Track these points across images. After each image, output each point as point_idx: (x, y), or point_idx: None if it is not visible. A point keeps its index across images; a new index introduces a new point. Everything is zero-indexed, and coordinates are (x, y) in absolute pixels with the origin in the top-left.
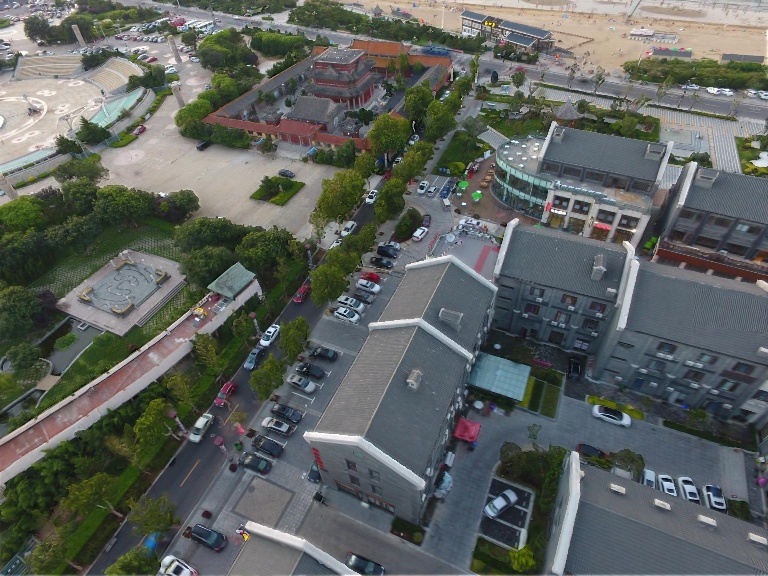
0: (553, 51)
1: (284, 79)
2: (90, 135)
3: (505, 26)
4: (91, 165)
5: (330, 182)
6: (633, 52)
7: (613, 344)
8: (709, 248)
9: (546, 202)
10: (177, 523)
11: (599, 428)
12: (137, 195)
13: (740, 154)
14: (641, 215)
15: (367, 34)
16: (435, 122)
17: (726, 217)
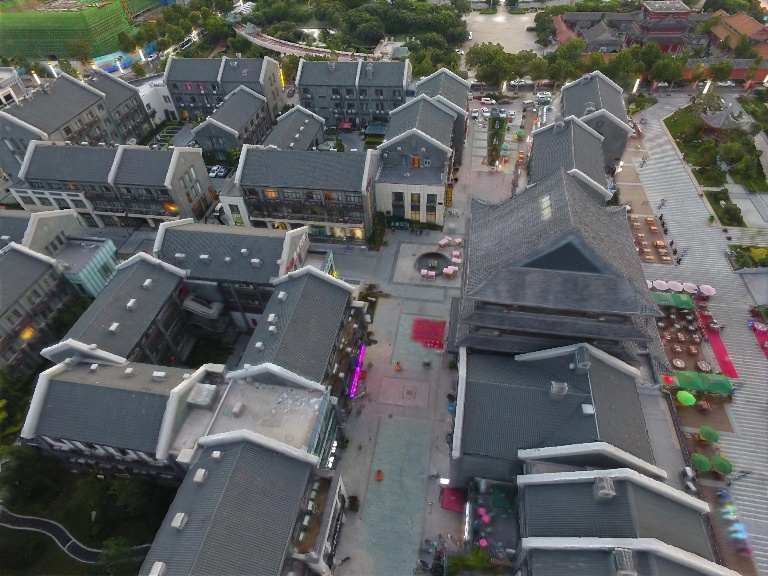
0: None
1: None
2: (508, 1)
3: None
4: (463, 3)
5: (483, 44)
6: None
7: None
8: None
9: None
10: (290, 79)
11: None
12: (449, 20)
13: None
14: None
15: None
16: (607, 63)
17: None
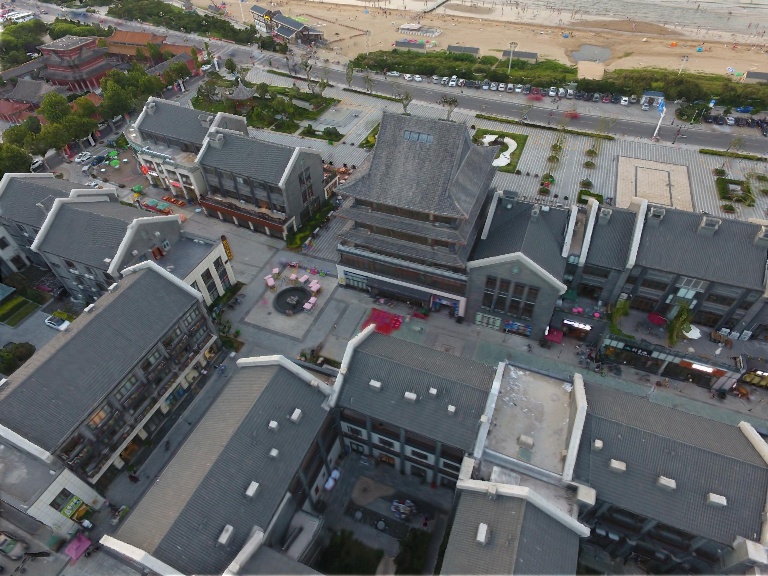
0: (315, 42)
1: (37, 65)
2: None
3: (276, 19)
4: None
5: None
6: (390, 44)
7: (49, 265)
8: (236, 199)
9: (142, 165)
10: None
11: (44, 333)
12: None
13: (374, 129)
14: (187, 173)
15: (166, 26)
16: (107, 101)
17: (225, 171)
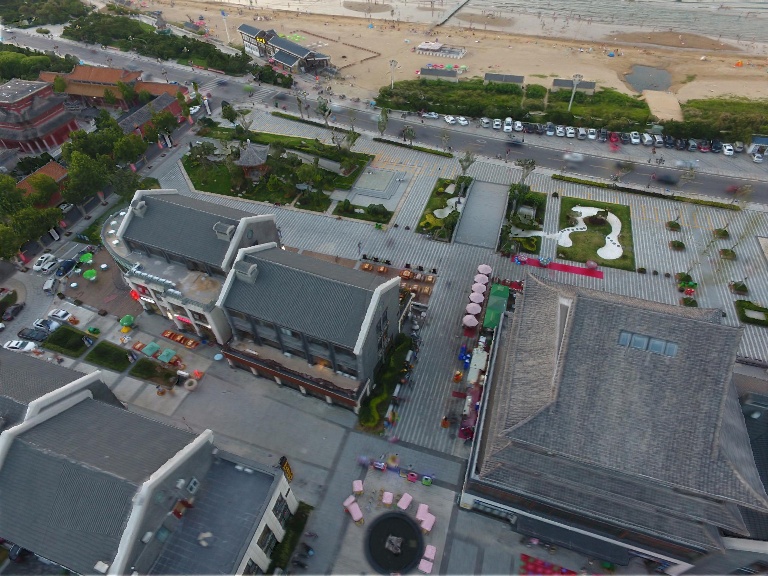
0: (322, 70)
1: None
2: None
3: (272, 43)
4: None
5: None
6: (410, 70)
7: None
8: (277, 349)
9: None
10: None
11: None
12: None
13: (429, 202)
14: (202, 311)
15: (136, 51)
16: (73, 179)
17: (264, 320)
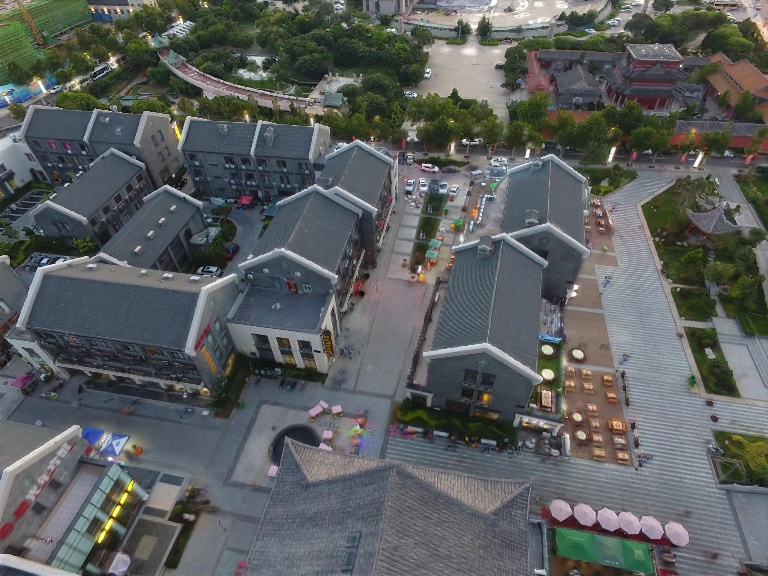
0: None
1: None
2: (479, 29)
3: None
4: (424, 33)
5: (428, 96)
6: None
7: None
8: None
9: None
10: None
11: None
12: (403, 55)
13: None
14: None
15: None
16: (576, 128)
17: None
